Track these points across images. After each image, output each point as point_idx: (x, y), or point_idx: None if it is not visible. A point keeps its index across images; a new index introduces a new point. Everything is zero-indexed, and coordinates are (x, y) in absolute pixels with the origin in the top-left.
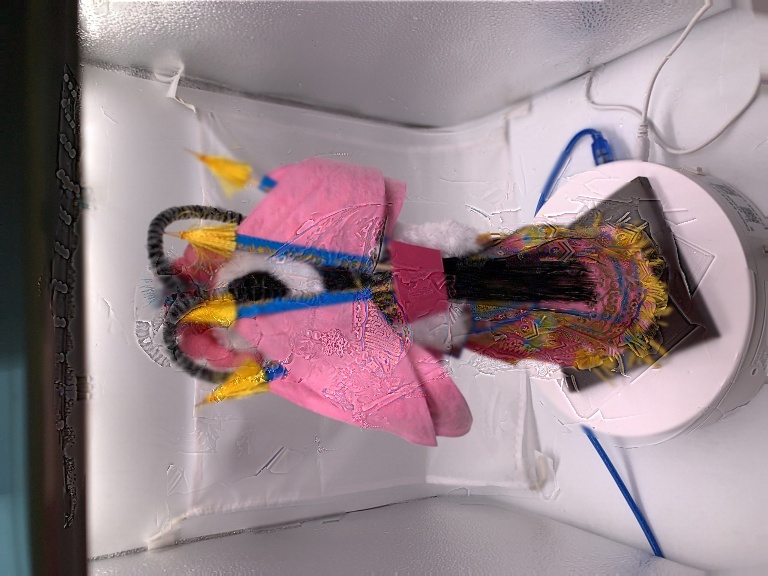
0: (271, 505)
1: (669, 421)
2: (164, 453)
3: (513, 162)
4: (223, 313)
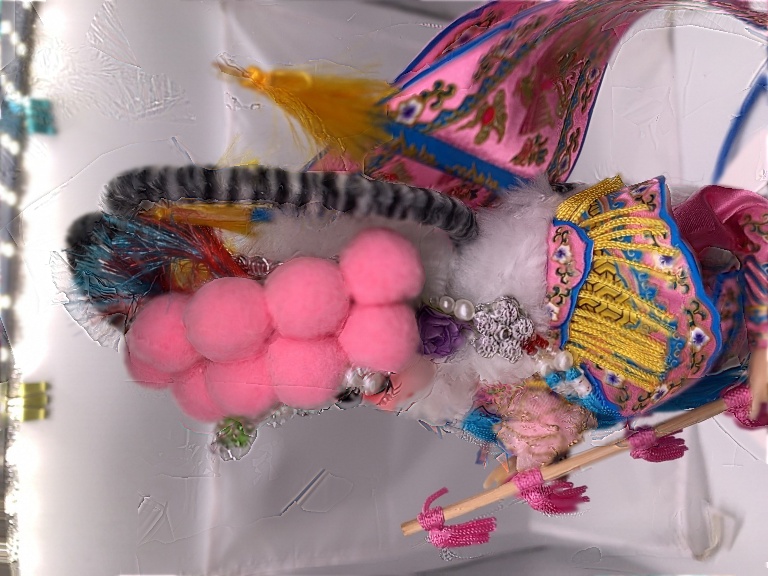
0: (302, 563)
1: None
2: (136, 478)
3: (682, 59)
4: (252, 243)
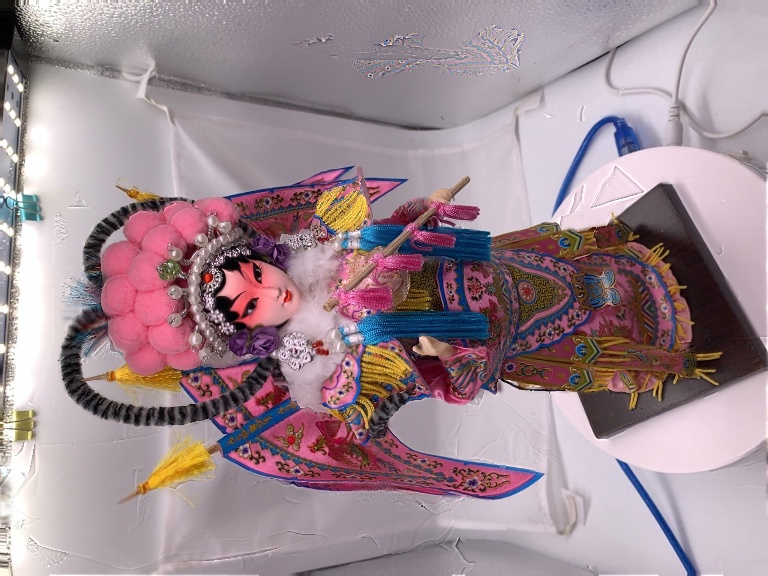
0: None
1: None
2: None
3: (504, 410)
4: None
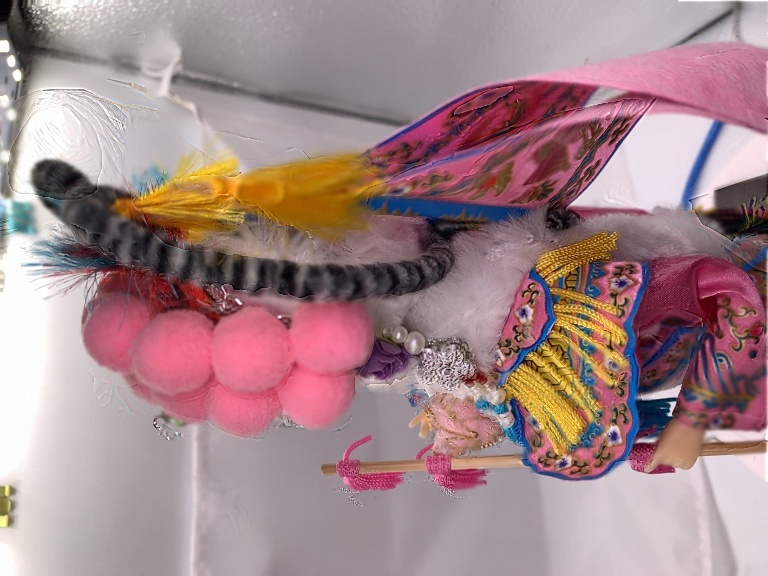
0: None
1: None
2: None
3: None
4: None
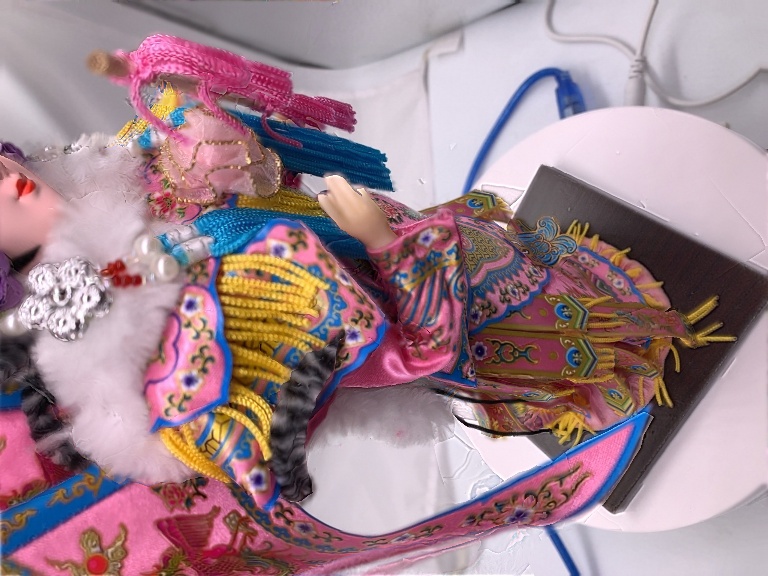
0: None
1: (704, 145)
2: None
3: None
4: None
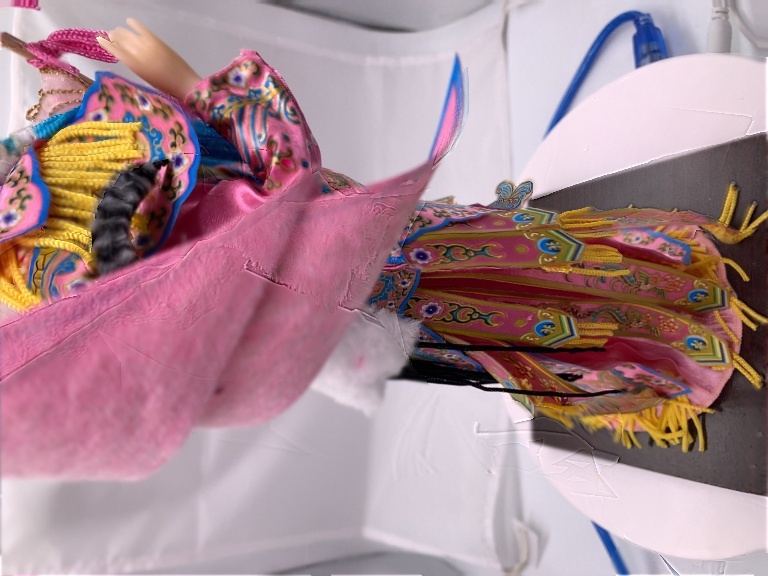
0: None
1: (646, 89)
2: None
3: None
4: None
